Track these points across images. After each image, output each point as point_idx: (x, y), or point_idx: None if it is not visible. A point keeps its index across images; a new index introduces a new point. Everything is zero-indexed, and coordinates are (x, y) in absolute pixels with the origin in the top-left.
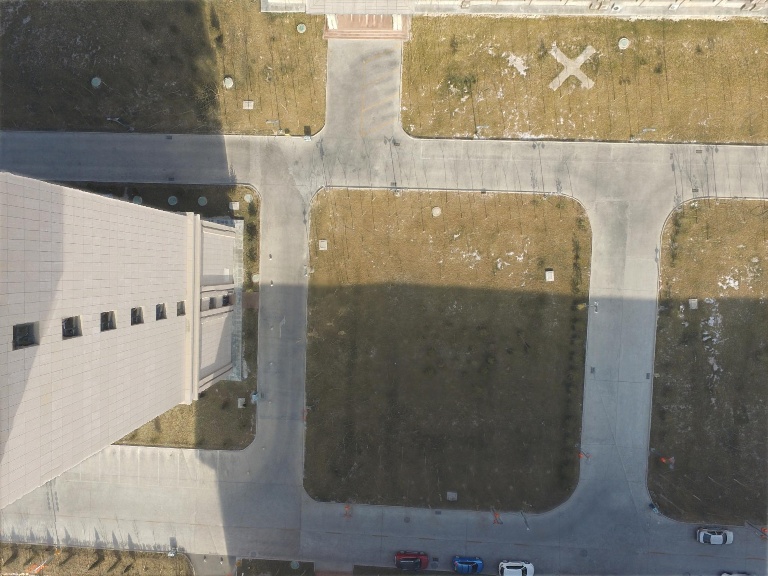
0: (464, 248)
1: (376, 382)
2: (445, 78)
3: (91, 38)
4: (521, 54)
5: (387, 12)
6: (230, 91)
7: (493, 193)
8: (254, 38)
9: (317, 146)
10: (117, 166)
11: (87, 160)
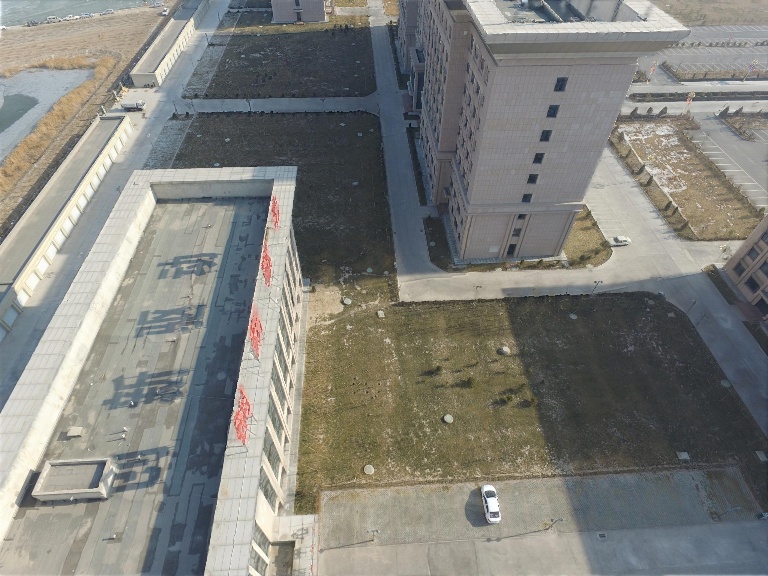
0: None
1: None
2: None
3: None
4: None
5: None
6: (355, 26)
7: None
8: None
9: None
10: (384, 41)
11: None
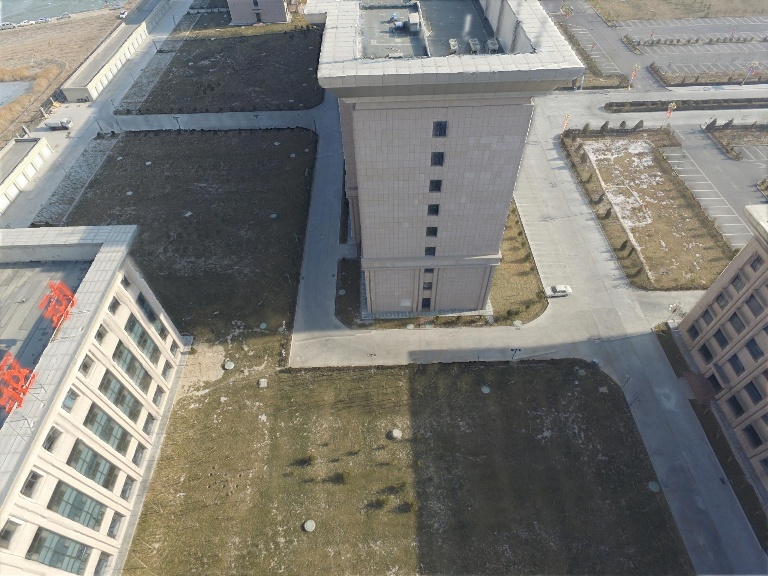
0: None
1: None
2: None
3: None
4: None
5: None
6: None
7: None
8: None
9: None
10: None
11: None
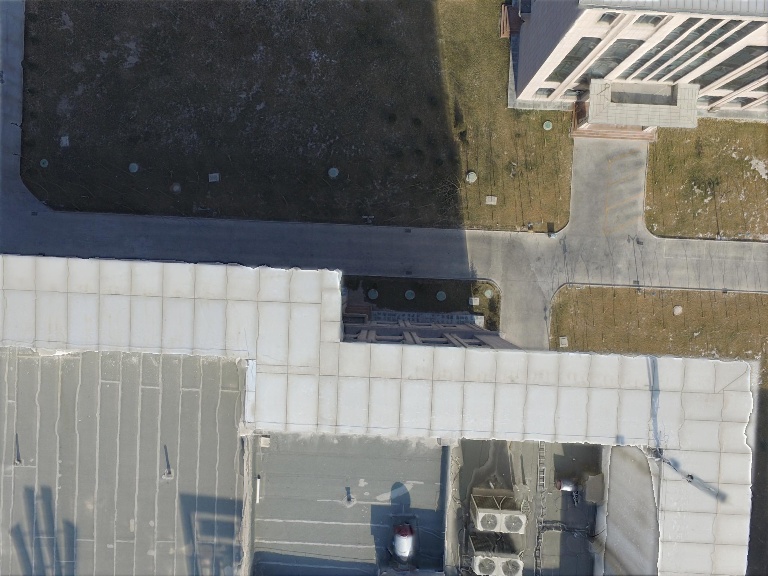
0: (703, 346)
1: (612, 479)
2: (689, 179)
3: (329, 127)
4: (763, 158)
5: (670, 125)
6: (473, 186)
7: (734, 293)
8: (499, 133)
9: (560, 243)
10: (352, 258)
11: (320, 252)
